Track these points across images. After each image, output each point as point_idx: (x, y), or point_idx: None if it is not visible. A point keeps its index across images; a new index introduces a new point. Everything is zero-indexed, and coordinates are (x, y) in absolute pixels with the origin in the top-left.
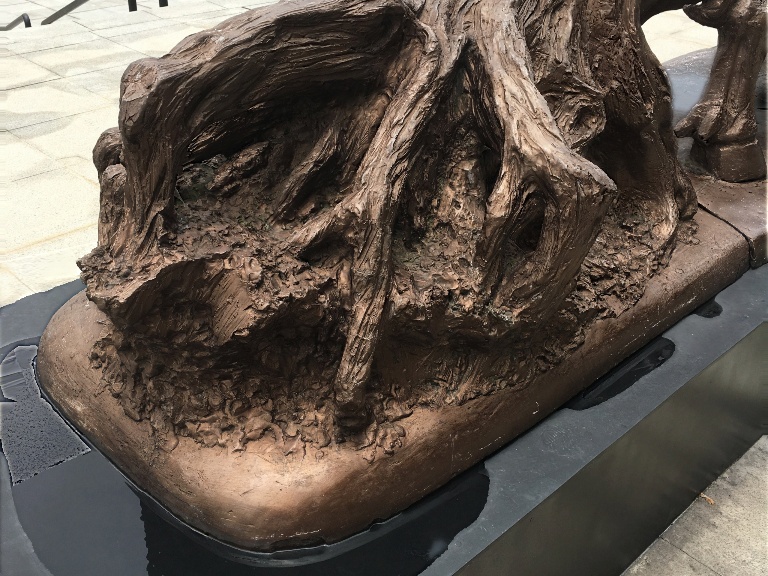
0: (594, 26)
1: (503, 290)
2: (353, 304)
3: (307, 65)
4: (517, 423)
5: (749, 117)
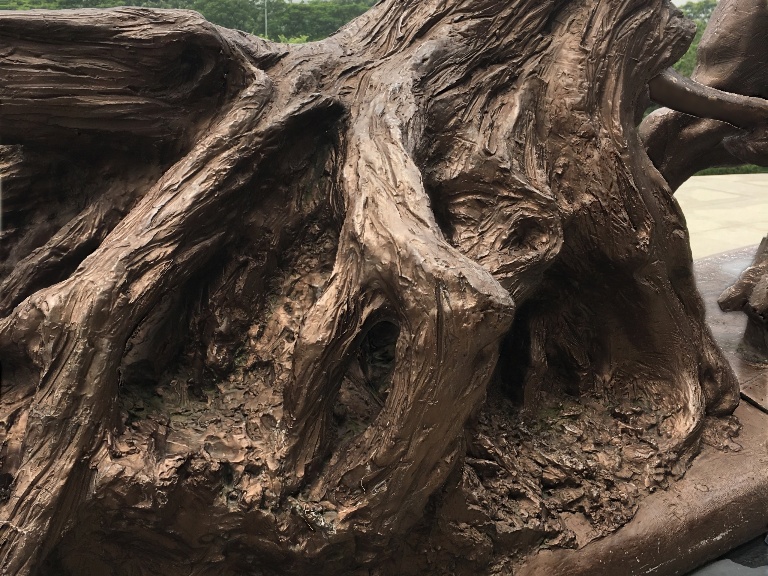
0: (556, 118)
1: (330, 473)
2: (19, 466)
3: (39, 97)
4: None
5: None
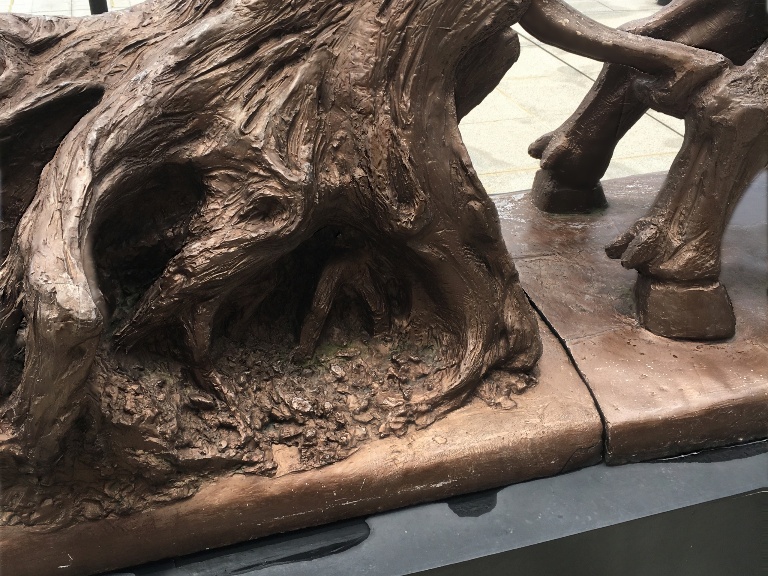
0: (340, 92)
1: (6, 406)
2: None
3: None
4: (27, 572)
5: (702, 251)
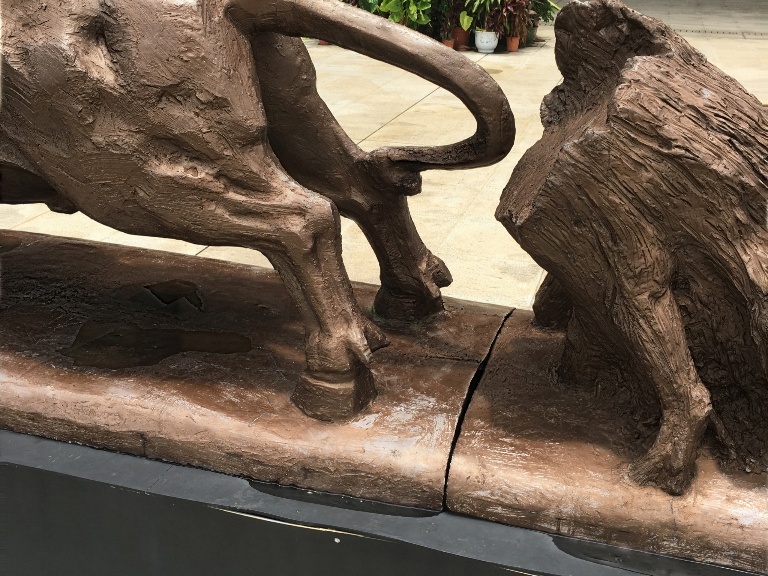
0: None
1: None
2: None
3: None
4: None
5: None
